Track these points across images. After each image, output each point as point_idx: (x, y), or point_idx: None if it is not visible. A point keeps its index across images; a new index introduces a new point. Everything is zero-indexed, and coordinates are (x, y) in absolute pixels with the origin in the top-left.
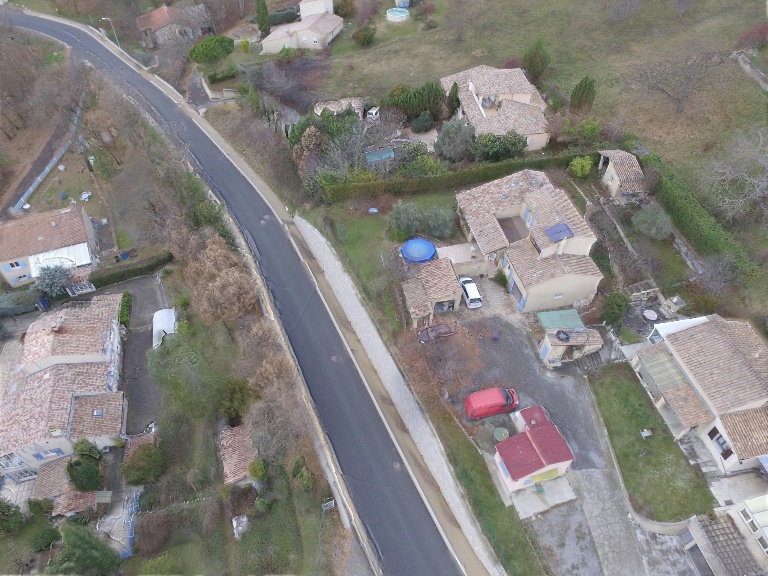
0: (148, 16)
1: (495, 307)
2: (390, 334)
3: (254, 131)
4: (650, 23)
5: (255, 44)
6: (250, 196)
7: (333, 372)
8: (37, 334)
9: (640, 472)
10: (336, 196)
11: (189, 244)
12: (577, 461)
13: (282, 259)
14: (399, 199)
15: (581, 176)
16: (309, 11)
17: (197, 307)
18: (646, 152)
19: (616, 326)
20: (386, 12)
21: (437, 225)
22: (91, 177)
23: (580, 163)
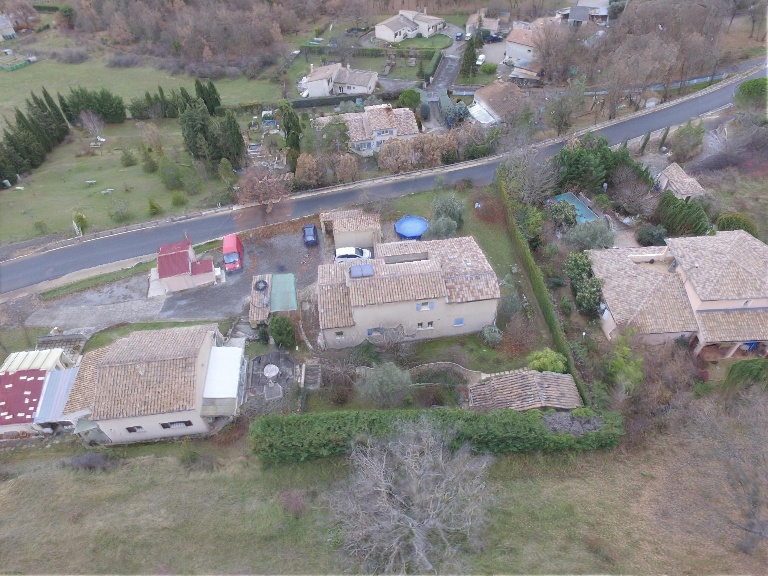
0: None
1: None
2: None
3: (630, 146)
4: None
5: None
6: None
7: None
8: (383, 105)
9: (139, 329)
10: None
11: None
12: (171, 302)
13: None
14: (465, 200)
15: None
16: None
17: None
18: (561, 426)
19: None
20: None
21: None
22: None
23: (547, 356)
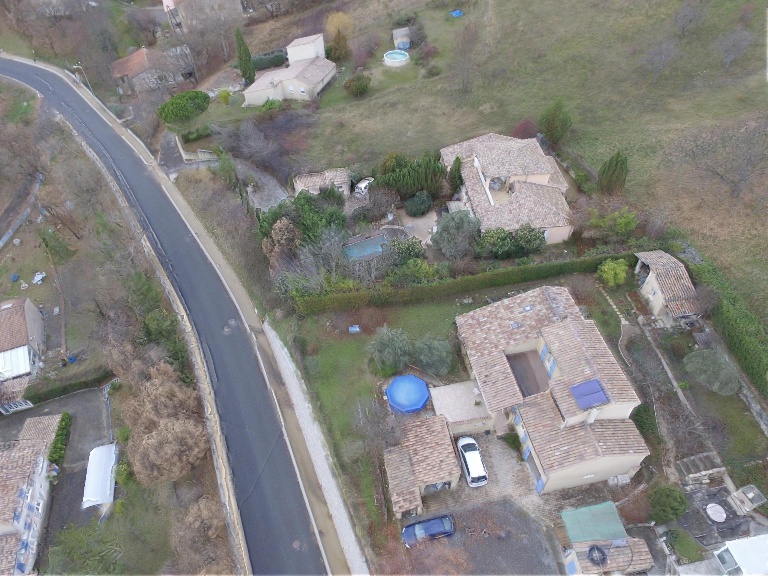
0: (127, 60)
1: (505, 484)
2: (365, 530)
3: (225, 208)
4: (689, 73)
5: (237, 94)
6: (216, 291)
7: (294, 568)
8: None
9: None
10: (310, 308)
11: (131, 370)
12: None
13: (244, 384)
14: None
15: (613, 285)
16: (298, 56)
17: (132, 460)
18: (697, 258)
19: (671, 537)
20: (383, 56)
21: (431, 361)
22: (48, 253)
23: (612, 269)
